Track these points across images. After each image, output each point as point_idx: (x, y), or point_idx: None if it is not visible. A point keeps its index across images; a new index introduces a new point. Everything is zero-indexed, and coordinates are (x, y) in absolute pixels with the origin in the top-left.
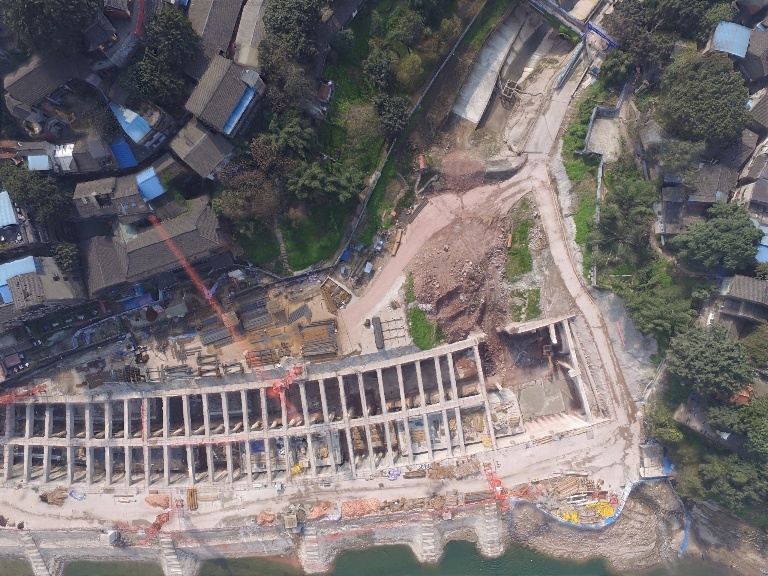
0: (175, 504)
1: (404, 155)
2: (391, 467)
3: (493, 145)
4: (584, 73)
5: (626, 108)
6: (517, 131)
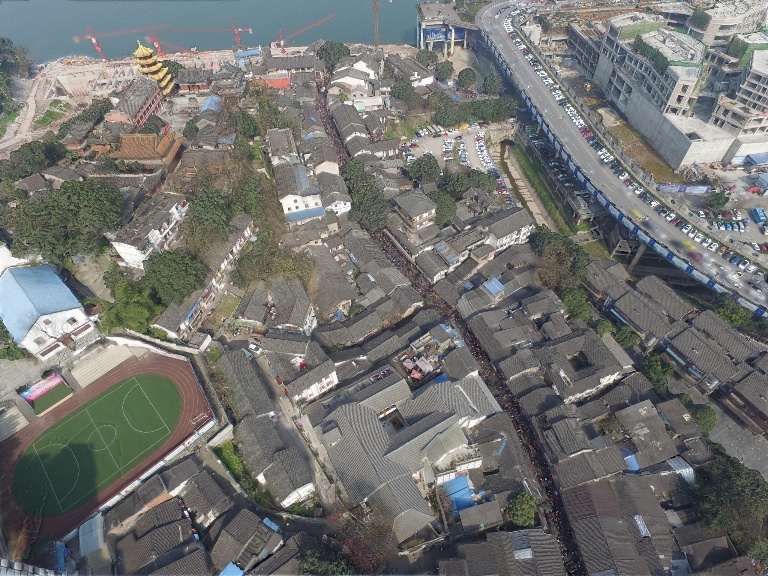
0: None
1: None
2: None
3: None
4: None
5: None
6: None
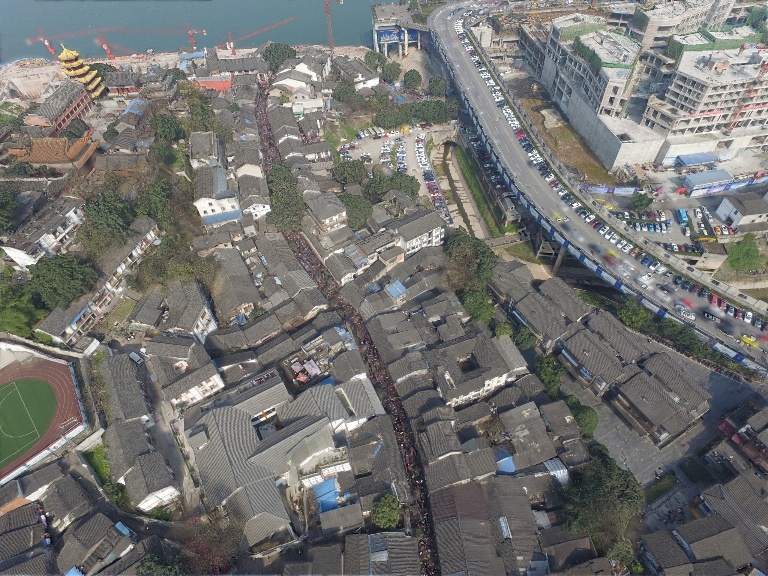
0: None
1: None
2: None
3: None
4: None
5: None
6: None
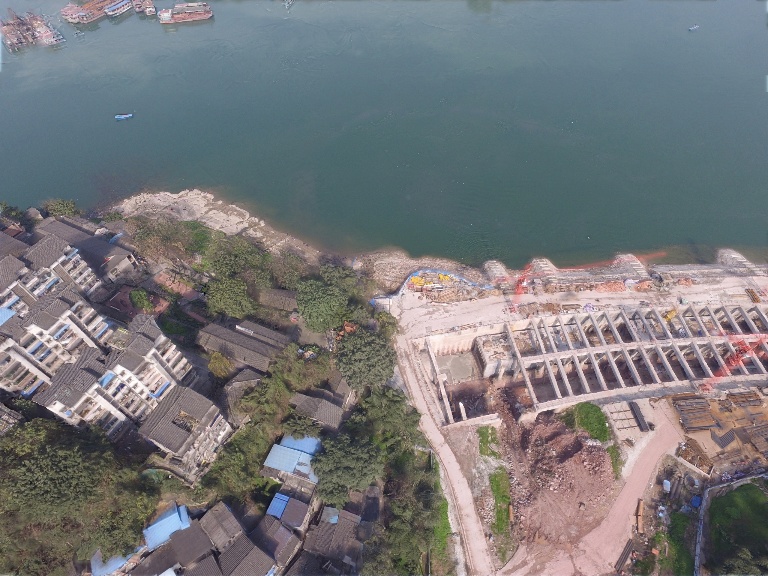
0: (766, 293)
1: None
2: (592, 313)
3: None
4: None
5: None
6: None
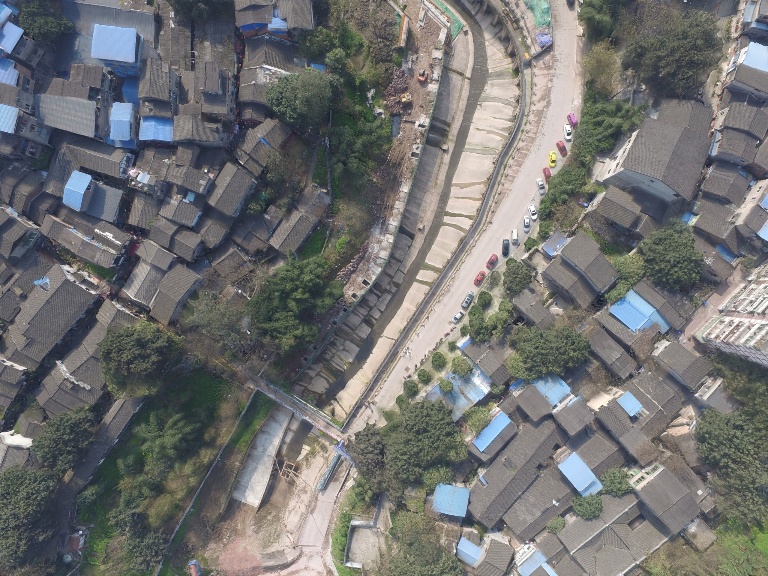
0: None
1: (179, 559)
2: None
3: (274, 529)
4: (346, 475)
5: (383, 517)
6: (293, 520)
